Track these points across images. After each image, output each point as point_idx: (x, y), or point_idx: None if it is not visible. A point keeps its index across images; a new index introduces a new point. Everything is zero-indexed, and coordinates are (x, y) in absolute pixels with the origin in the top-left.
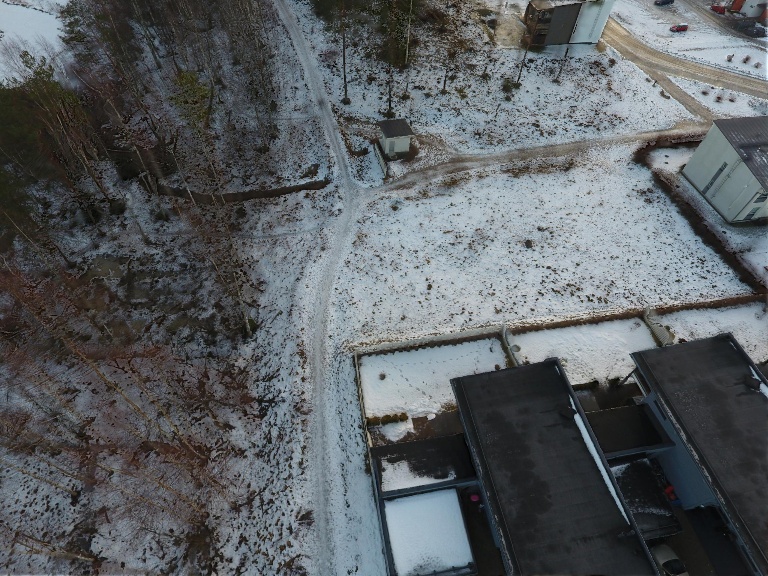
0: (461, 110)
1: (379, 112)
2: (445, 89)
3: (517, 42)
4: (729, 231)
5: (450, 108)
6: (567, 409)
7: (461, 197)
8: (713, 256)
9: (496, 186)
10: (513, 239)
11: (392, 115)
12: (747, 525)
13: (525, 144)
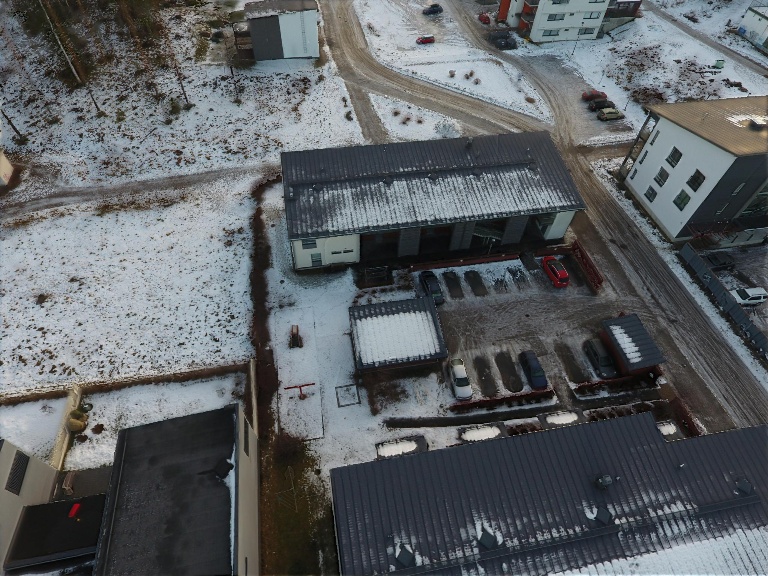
0: (105, 136)
1: (12, 138)
2: (104, 111)
3: (229, 57)
4: (288, 280)
5: (95, 133)
6: None
7: (13, 241)
8: (249, 312)
9: (67, 227)
10: (29, 293)
11: (23, 142)
12: None
13: (151, 175)
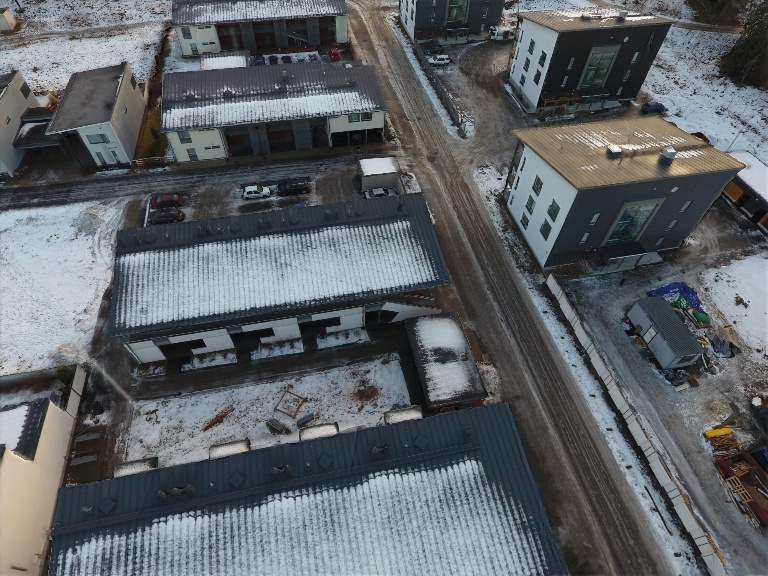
0: (75, 7)
1: (15, 10)
2: None
3: None
4: (178, 60)
5: (68, 6)
6: None
7: (18, 50)
8: (153, 73)
9: (50, 44)
10: (28, 68)
11: (22, 11)
12: None
13: (104, 25)
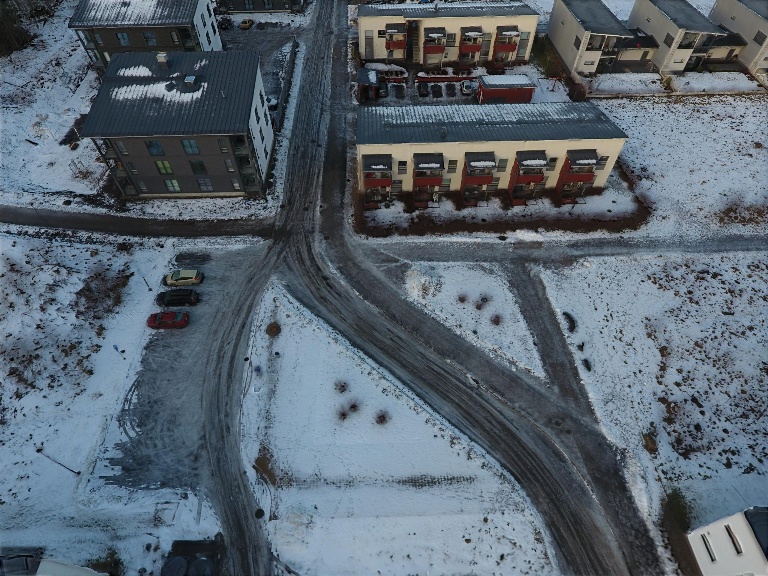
0: None
1: None
2: None
3: None
4: None
5: None
6: (766, 17)
7: None
8: None
9: None
10: None
11: None
12: (687, 3)
13: None
